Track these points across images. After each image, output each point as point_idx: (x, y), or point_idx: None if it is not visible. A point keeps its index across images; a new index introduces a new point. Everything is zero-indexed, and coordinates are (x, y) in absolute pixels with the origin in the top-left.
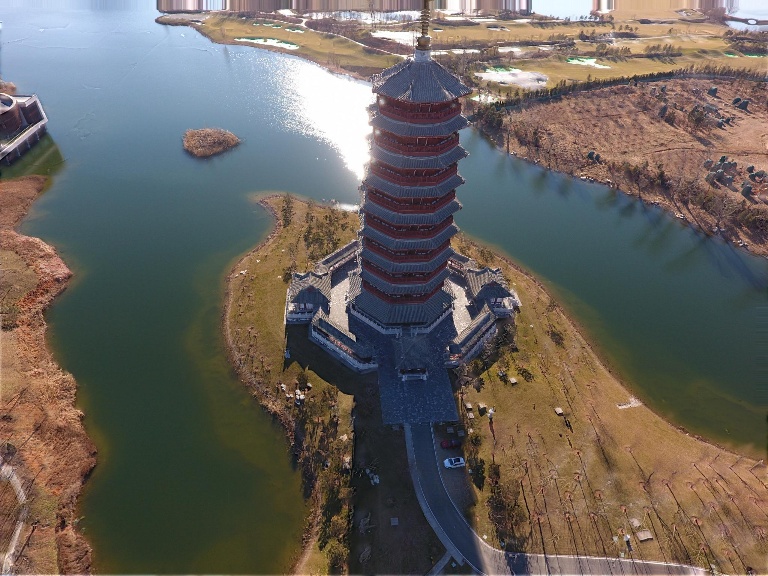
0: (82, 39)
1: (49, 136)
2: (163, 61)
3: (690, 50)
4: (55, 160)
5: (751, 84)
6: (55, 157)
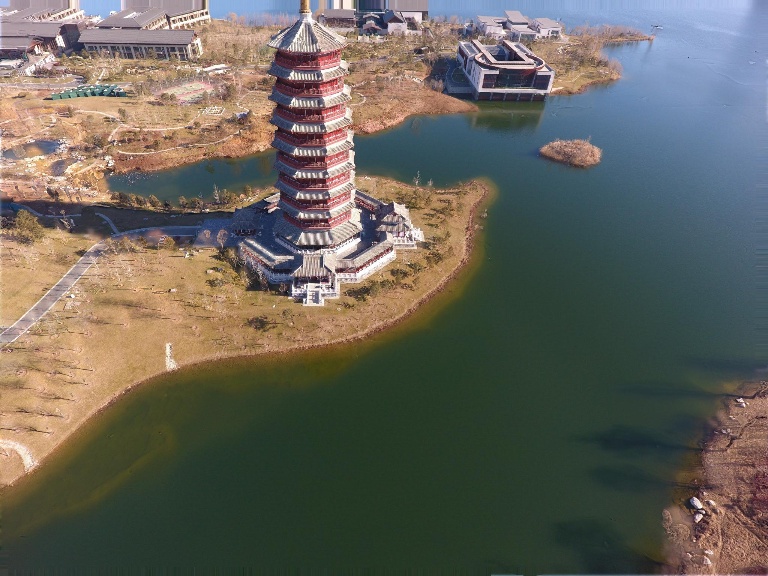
0: (765, 79)
1: (544, 104)
2: (756, 114)
3: None
4: (533, 120)
5: None
6: (535, 119)
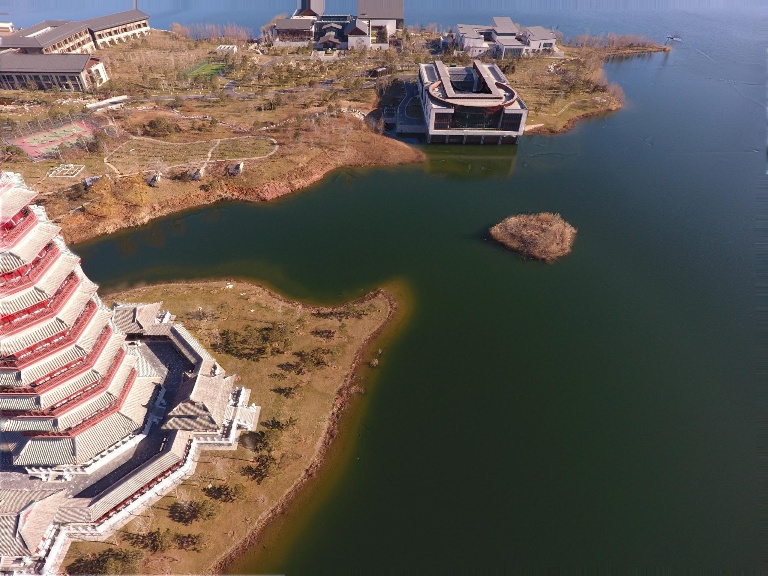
0: None
1: (516, 148)
2: None
3: None
4: (503, 167)
5: None
6: (505, 165)
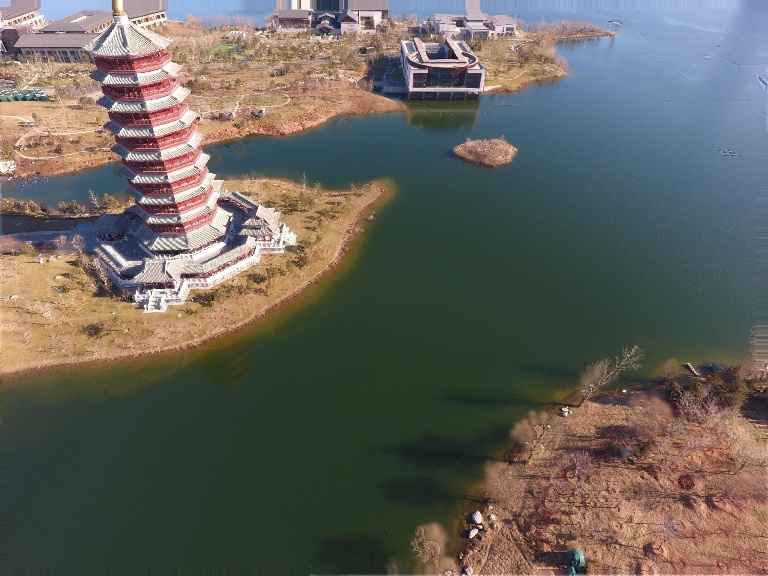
0: (717, 74)
1: (478, 102)
2: (692, 110)
3: None
4: (469, 119)
5: None
6: (471, 118)
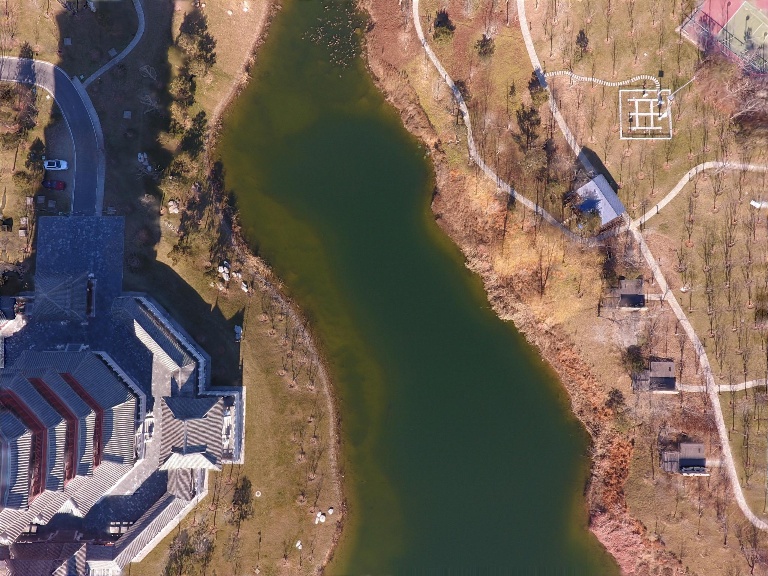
0: None
1: None
2: None
3: None
4: None
5: None
6: None
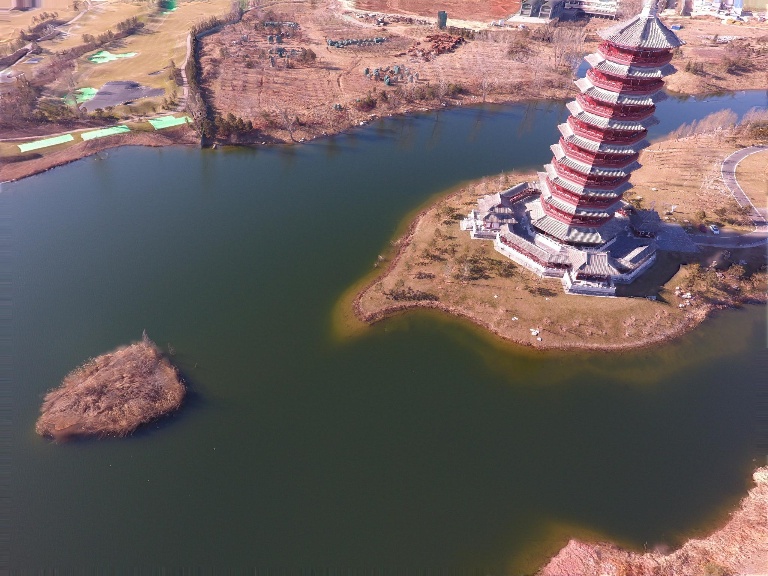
0: None
1: None
2: None
3: (140, 17)
4: None
5: (250, 25)
6: None
